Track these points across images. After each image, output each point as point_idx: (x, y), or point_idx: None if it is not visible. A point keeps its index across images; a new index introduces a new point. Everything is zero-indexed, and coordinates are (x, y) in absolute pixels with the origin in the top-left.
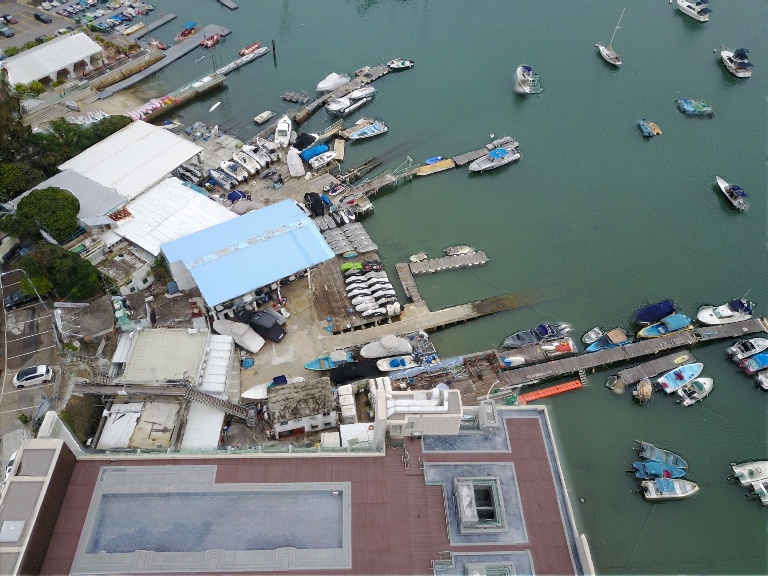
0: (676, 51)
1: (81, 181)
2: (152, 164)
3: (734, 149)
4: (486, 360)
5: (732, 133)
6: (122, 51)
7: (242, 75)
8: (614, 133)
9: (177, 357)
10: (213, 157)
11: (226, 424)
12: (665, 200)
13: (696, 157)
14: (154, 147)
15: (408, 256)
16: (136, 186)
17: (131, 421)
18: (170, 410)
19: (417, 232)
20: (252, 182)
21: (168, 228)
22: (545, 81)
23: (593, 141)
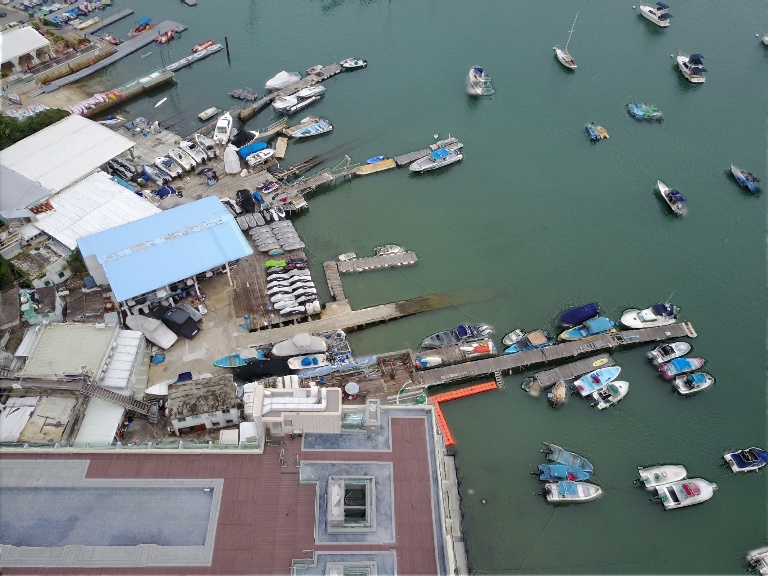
0: (634, 55)
1: (6, 174)
2: (81, 158)
3: (680, 154)
4: (400, 360)
5: (679, 138)
6: (71, 45)
7: (194, 72)
8: (561, 136)
9: (81, 352)
10: (151, 153)
11: (127, 420)
12: (605, 203)
13: (641, 161)
14: (86, 141)
15: (338, 255)
16: (62, 180)
17: (24, 415)
18: (66, 405)
19: (350, 231)
20: (186, 178)
21: (89, 222)
22: (497, 83)
23: (539, 143)
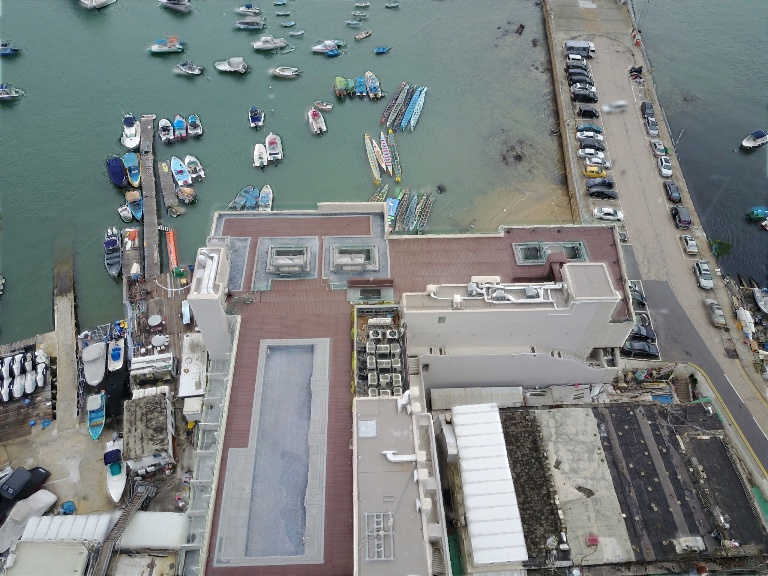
0: None
1: None
2: None
3: None
4: (132, 286)
5: None
6: None
7: None
8: None
9: (47, 575)
10: None
11: None
12: None
13: None
14: None
15: None
16: None
17: None
18: (126, 565)
19: None
20: None
21: None
22: None
23: None
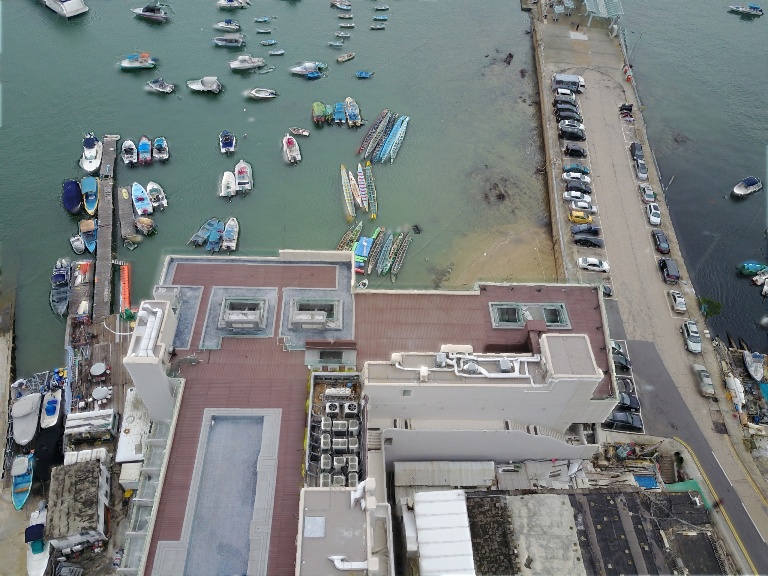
0: None
1: None
2: None
3: None
4: (76, 328)
5: None
6: None
7: None
8: None
9: None
10: None
11: None
12: None
13: None
14: None
15: None
16: None
17: None
18: None
19: None
20: None
21: None
22: None
23: None
